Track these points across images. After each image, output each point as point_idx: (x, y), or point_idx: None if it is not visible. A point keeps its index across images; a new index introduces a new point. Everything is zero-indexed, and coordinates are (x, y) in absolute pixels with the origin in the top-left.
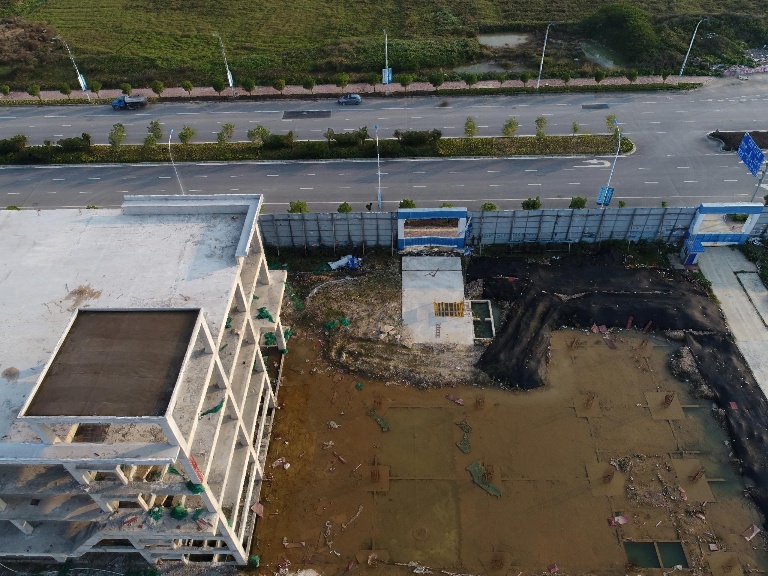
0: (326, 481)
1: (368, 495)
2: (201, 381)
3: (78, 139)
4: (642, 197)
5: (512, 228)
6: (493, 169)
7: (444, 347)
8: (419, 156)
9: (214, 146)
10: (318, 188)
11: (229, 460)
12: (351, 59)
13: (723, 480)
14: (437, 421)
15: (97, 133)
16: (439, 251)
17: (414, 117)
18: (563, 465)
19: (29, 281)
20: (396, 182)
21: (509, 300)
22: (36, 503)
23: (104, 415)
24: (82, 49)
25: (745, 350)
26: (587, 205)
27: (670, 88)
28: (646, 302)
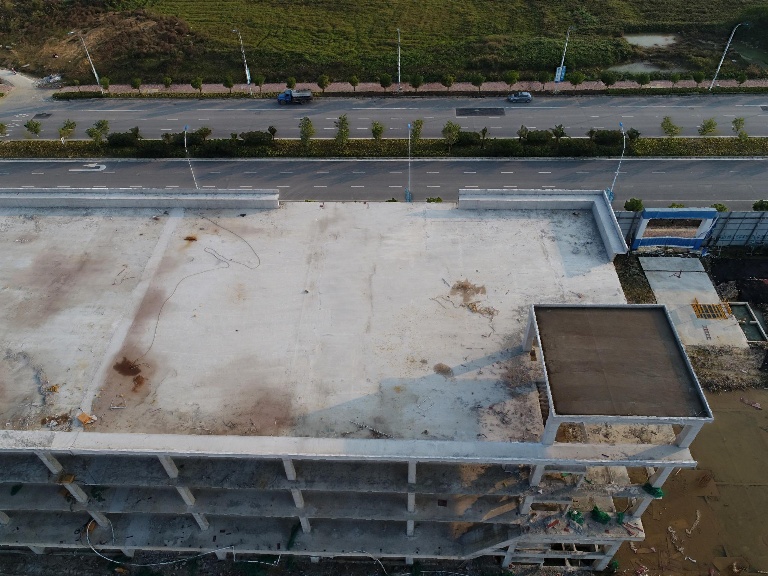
0: None
1: (700, 500)
2: None
3: (261, 133)
4: None
5: (755, 230)
6: (696, 170)
7: (720, 350)
8: (615, 155)
9: (399, 142)
10: (522, 186)
11: None
12: (504, 57)
13: None
14: (741, 425)
15: None
16: (674, 252)
17: (592, 116)
18: None
19: (401, 275)
20: (600, 181)
21: None
22: (444, 504)
23: (641, 415)
24: (222, 43)
25: None
26: None
27: None
28: None
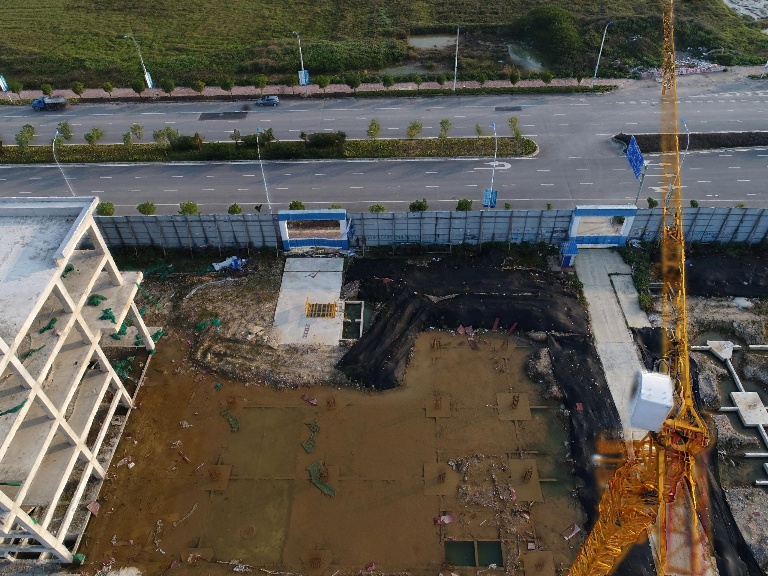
0: (167, 480)
1: (205, 494)
2: None
3: None
4: (535, 199)
5: (394, 230)
6: (394, 171)
7: (309, 348)
8: (324, 158)
9: (124, 147)
10: (219, 189)
11: (37, 459)
12: (277, 60)
13: (555, 480)
14: (288, 421)
15: (13, 134)
16: (324, 252)
17: (328, 119)
18: (402, 465)
19: None
20: (297, 184)
21: (381, 301)
22: None
23: None
24: (15, 50)
25: (602, 351)
26: (479, 207)
27: (585, 90)
28: (513, 304)
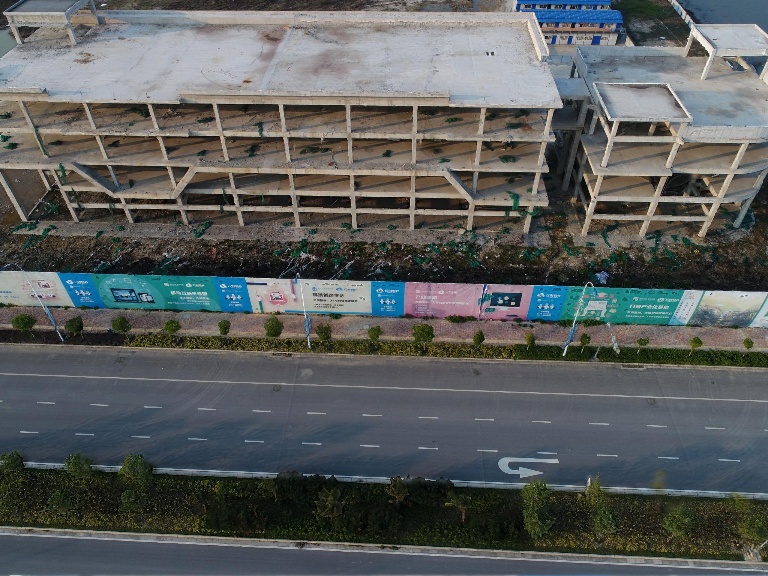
0: None
1: None
2: (31, 36)
3: (223, 518)
4: None
5: None
6: None
7: None
8: None
9: None
10: None
11: None
12: None
13: None
14: None
15: None
16: None
17: None
18: None
19: (117, 66)
20: None
21: None
22: None
23: None
24: None
25: None
26: None
27: None
28: None
